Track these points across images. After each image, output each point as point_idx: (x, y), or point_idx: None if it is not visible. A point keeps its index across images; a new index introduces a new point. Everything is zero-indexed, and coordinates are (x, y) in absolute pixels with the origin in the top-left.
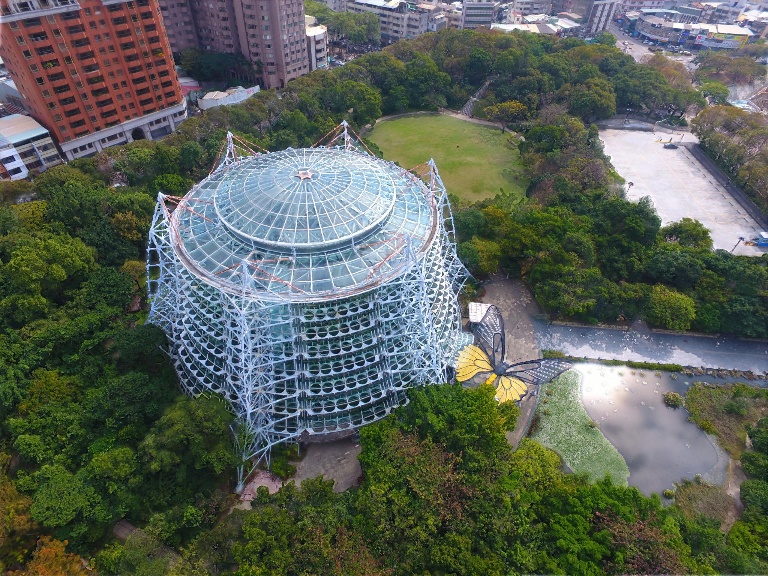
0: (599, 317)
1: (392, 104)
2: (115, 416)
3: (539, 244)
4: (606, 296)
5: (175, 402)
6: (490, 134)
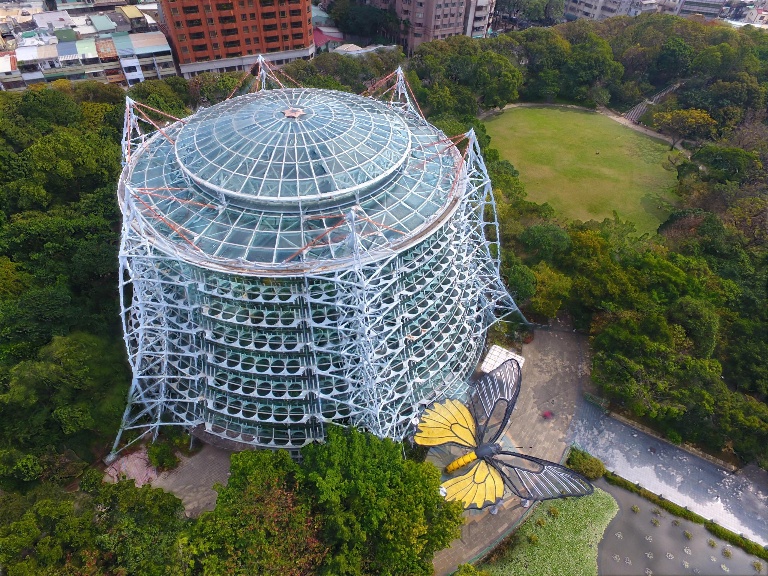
0: (686, 435)
1: (537, 89)
2: (12, 327)
3: (631, 299)
4: (707, 408)
5: (97, 336)
6: (651, 148)
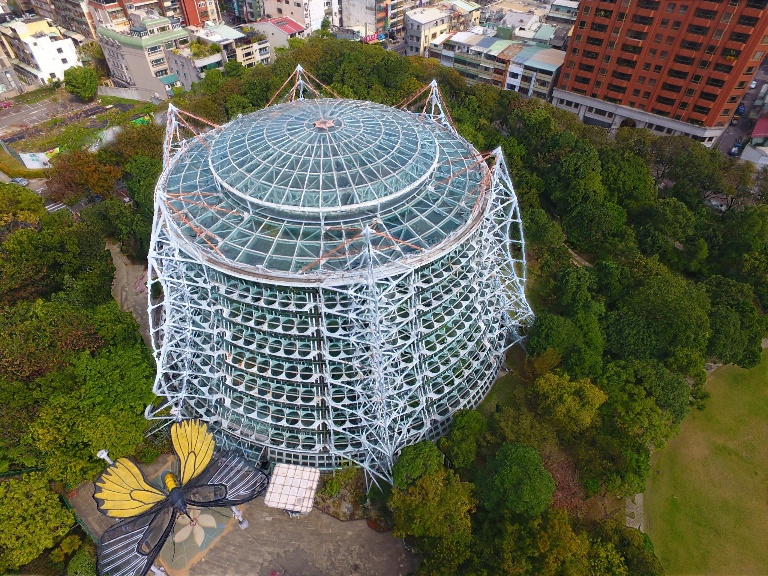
0: None
1: None
2: None
3: None
4: None
5: None
6: None
